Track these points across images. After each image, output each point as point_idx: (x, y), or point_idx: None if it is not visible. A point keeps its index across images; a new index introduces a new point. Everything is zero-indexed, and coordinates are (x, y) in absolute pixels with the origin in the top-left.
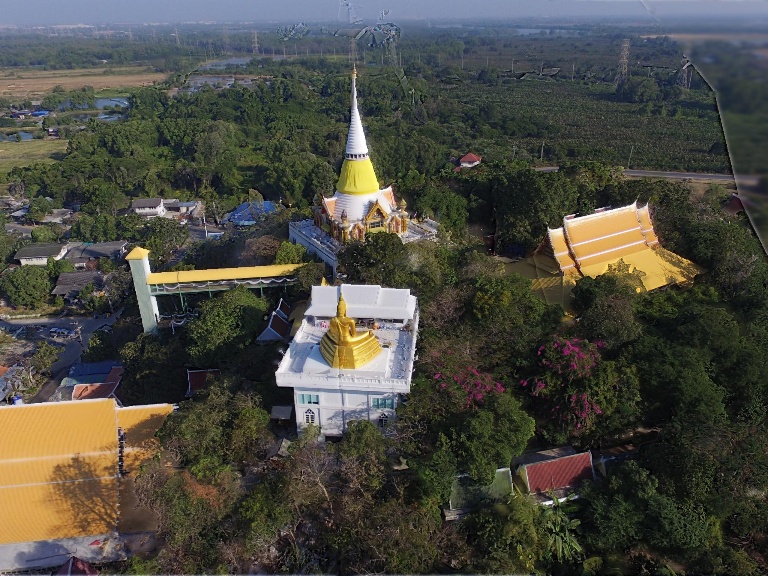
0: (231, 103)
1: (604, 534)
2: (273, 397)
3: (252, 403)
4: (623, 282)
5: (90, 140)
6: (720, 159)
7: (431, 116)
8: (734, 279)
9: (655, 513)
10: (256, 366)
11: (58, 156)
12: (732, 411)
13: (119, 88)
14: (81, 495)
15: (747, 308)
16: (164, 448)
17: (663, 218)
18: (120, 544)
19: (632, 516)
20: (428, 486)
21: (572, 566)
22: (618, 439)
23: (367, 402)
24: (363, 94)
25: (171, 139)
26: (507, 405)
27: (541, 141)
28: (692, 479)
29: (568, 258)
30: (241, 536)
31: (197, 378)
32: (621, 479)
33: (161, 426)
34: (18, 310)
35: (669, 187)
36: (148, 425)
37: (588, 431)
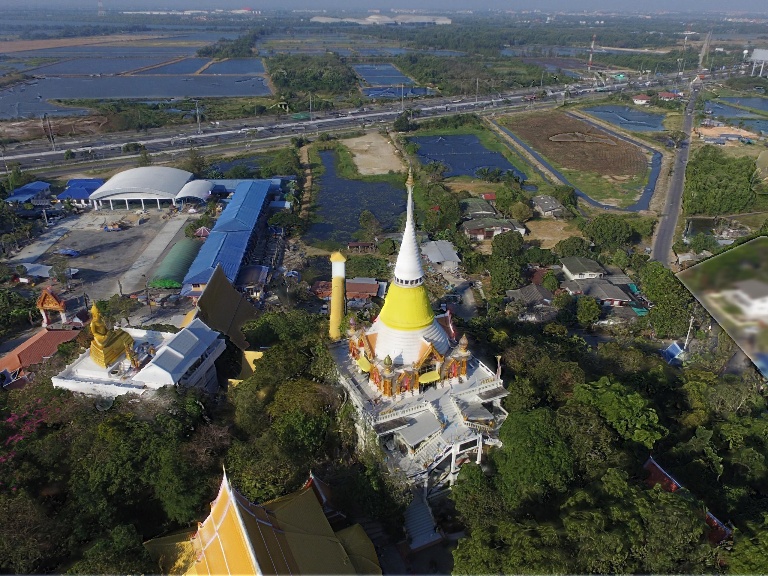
0: None
1: None
2: None
3: None
4: None
5: None
6: None
7: None
8: None
9: None
10: None
11: None
12: None
13: None
14: None
15: None
16: None
17: None
18: None
19: None
20: None
21: None
22: None
23: None
24: None
25: None
26: None
27: None
28: None
29: None
30: None
31: None
32: None
33: None
34: None
35: None
36: None
37: None
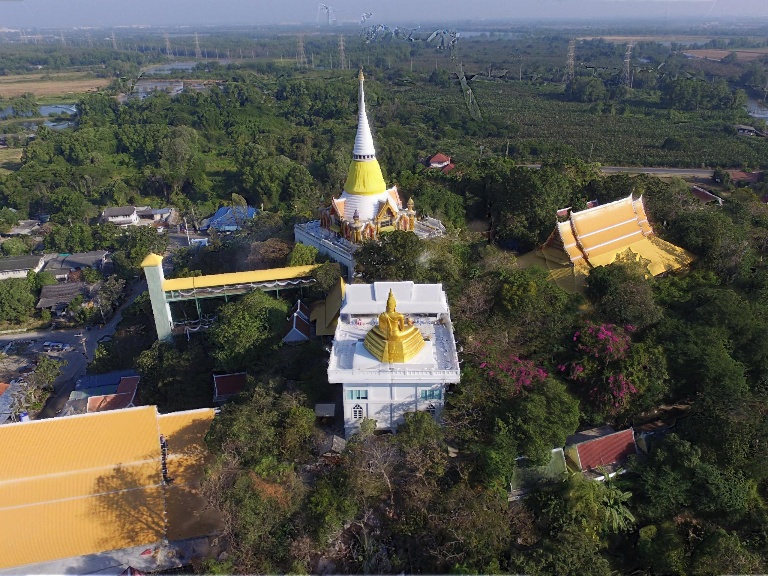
0: (186, 108)
1: (654, 504)
2: (317, 395)
3: (296, 402)
4: (634, 270)
5: (46, 148)
6: (673, 154)
7: (391, 118)
8: (729, 263)
9: (701, 480)
10: (292, 366)
11: (10, 166)
12: (749, 384)
13: (61, 94)
14: (126, 505)
15: (748, 289)
16: (211, 452)
17: (647, 210)
18: (172, 552)
19: (680, 485)
20: (492, 469)
21: (625, 536)
22: (645, 417)
23: (415, 394)
24: (319, 97)
25: (130, 146)
26: (555, 389)
27: (503, 140)
28: (732, 447)
29: (576, 249)
30: (313, 531)
31: (224, 382)
32: (666, 451)
33: (203, 431)
34: (2, 325)
35: (650, 180)
36: (190, 431)
37: (623, 410)
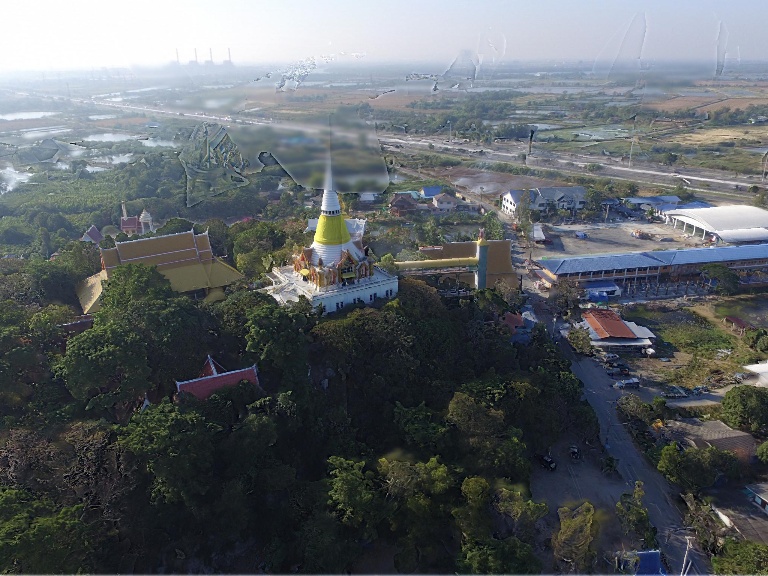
0: None
1: None
2: None
3: None
4: None
5: None
6: None
7: None
8: None
9: None
10: None
11: None
12: None
13: None
14: None
15: None
16: None
17: None
18: None
19: None
20: None
21: None
22: None
23: None
24: None
25: None
26: None
27: None
28: None
29: None
30: None
31: None
32: None
33: None
34: None
35: None
36: None
37: None
